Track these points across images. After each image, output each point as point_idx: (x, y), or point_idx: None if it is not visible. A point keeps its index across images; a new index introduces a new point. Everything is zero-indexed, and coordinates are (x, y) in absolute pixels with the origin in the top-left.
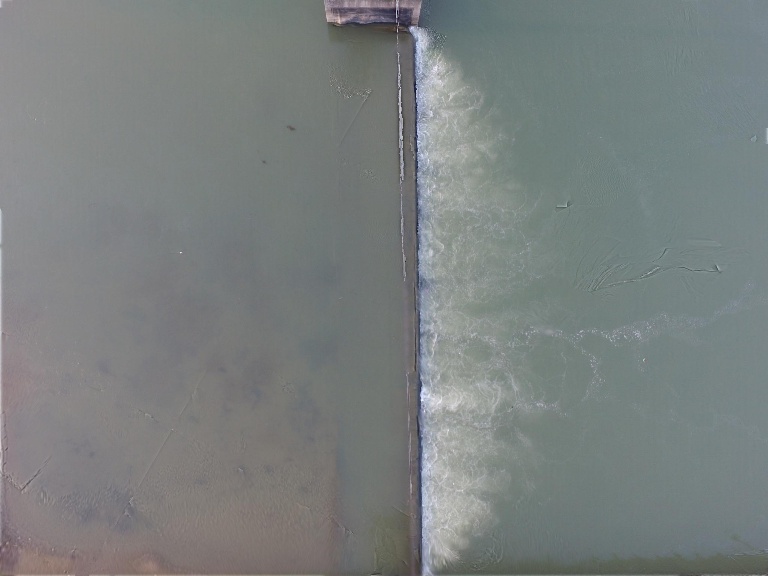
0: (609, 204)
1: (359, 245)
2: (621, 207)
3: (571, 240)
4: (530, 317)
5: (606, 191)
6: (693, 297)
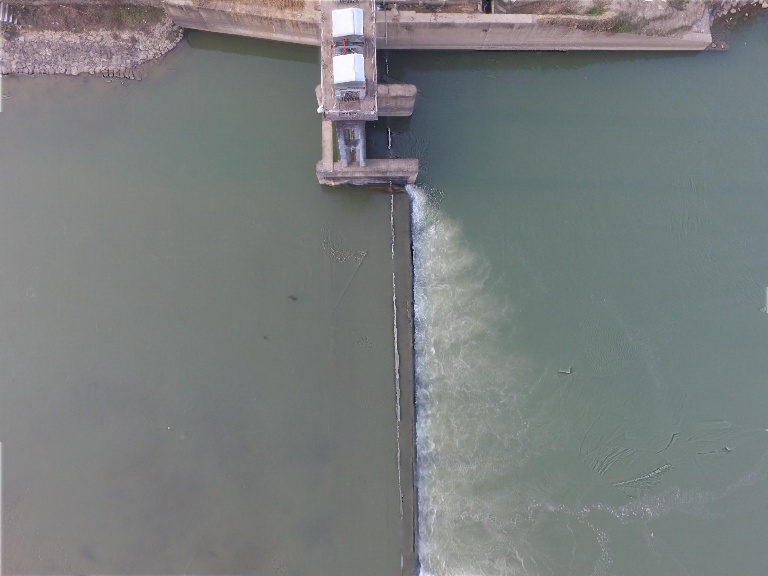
0: (614, 375)
1: (354, 417)
2: (626, 379)
3: (575, 411)
4: (533, 491)
5: (610, 359)
6: (701, 471)
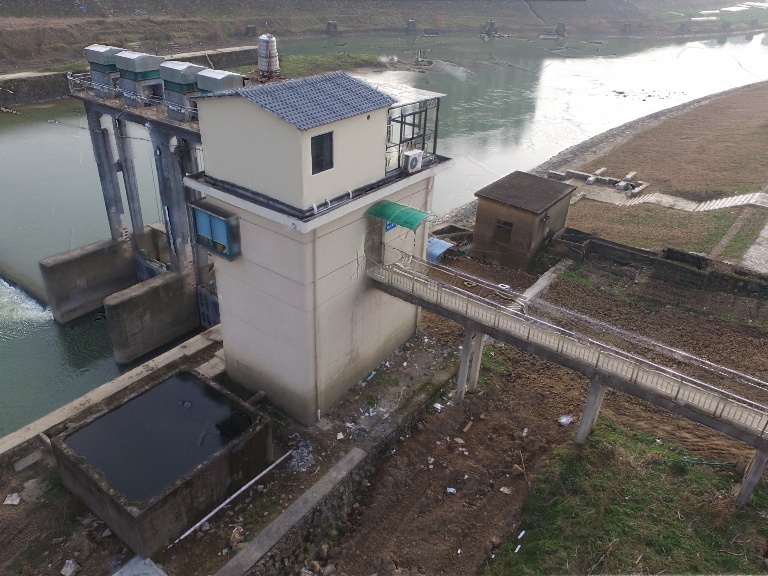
0: None
1: None
2: None
3: None
4: None
5: None
6: None
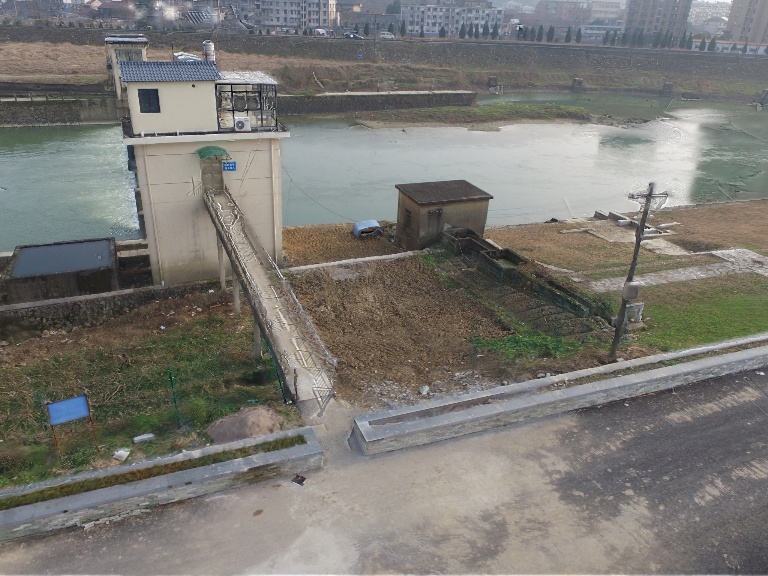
0: None
1: None
2: None
3: (1, 174)
4: None
5: None
6: None
